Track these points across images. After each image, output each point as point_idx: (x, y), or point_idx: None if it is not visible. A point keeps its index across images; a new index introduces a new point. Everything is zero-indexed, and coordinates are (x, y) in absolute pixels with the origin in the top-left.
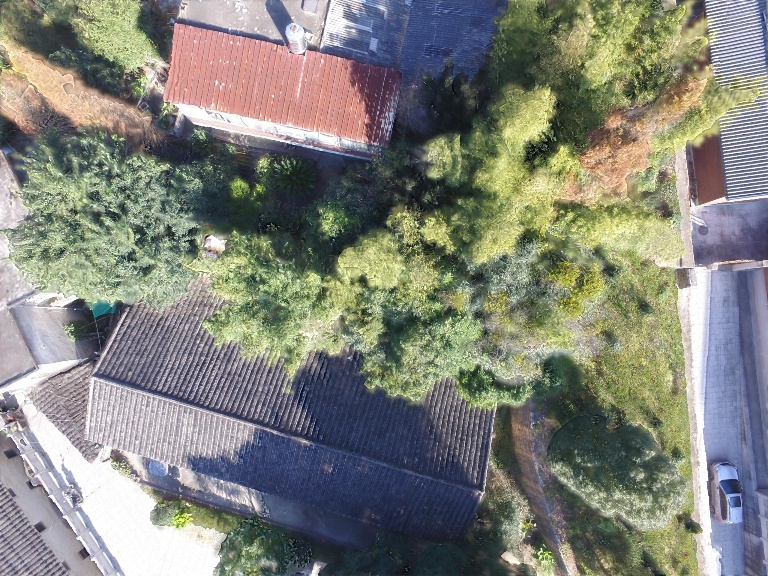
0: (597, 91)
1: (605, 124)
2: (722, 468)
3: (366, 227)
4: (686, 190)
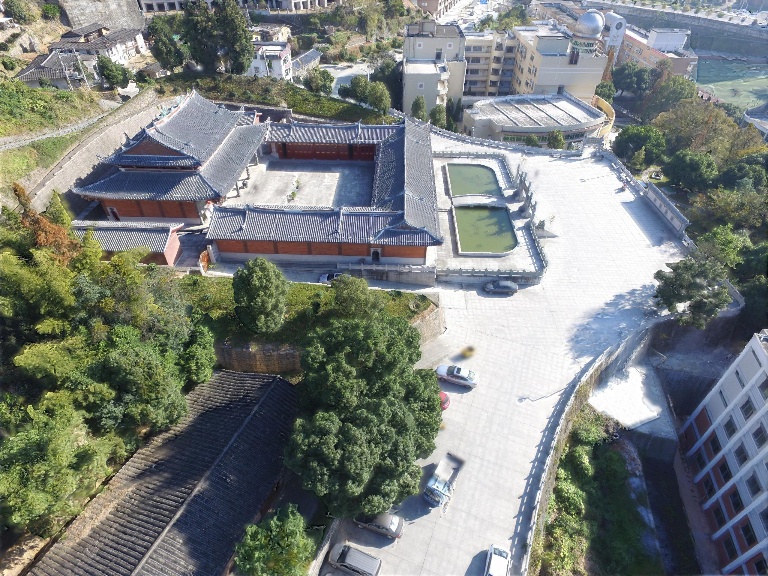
0: (18, 240)
1: (35, 239)
2: (321, 279)
3: (32, 394)
4: (147, 265)
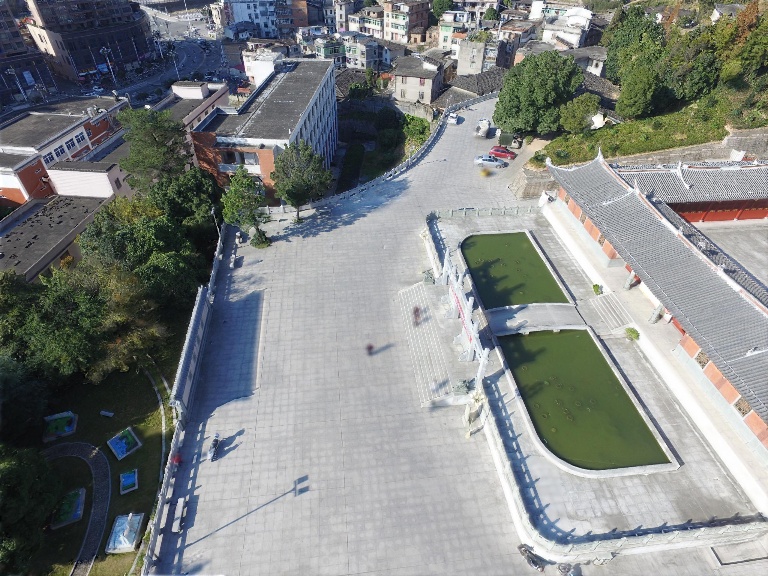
0: None
1: None
2: None
3: None
4: None
